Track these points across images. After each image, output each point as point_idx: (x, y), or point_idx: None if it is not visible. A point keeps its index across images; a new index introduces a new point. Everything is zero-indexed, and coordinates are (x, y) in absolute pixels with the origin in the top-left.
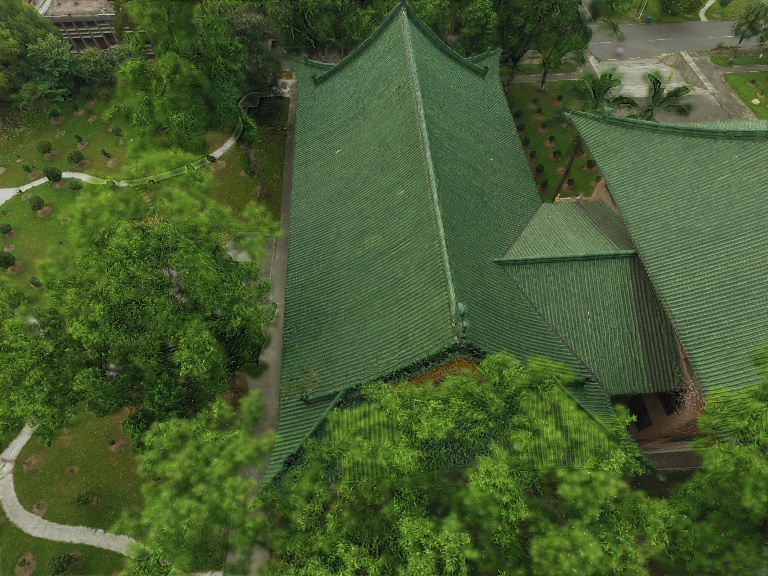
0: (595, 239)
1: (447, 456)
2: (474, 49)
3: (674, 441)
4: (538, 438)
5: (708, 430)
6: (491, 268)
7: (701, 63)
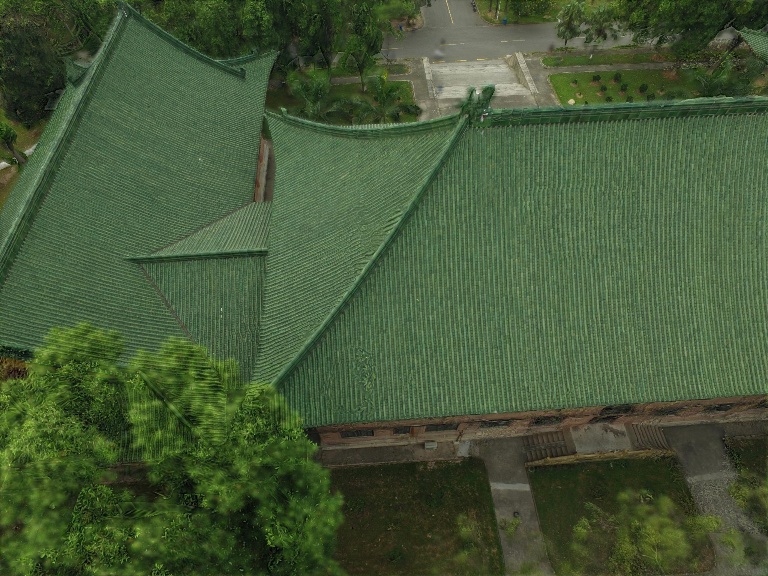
0: (261, 237)
1: (37, 450)
2: (259, 51)
3: (354, 436)
4: (131, 432)
5: (361, 425)
6: (118, 266)
7: (532, 64)
